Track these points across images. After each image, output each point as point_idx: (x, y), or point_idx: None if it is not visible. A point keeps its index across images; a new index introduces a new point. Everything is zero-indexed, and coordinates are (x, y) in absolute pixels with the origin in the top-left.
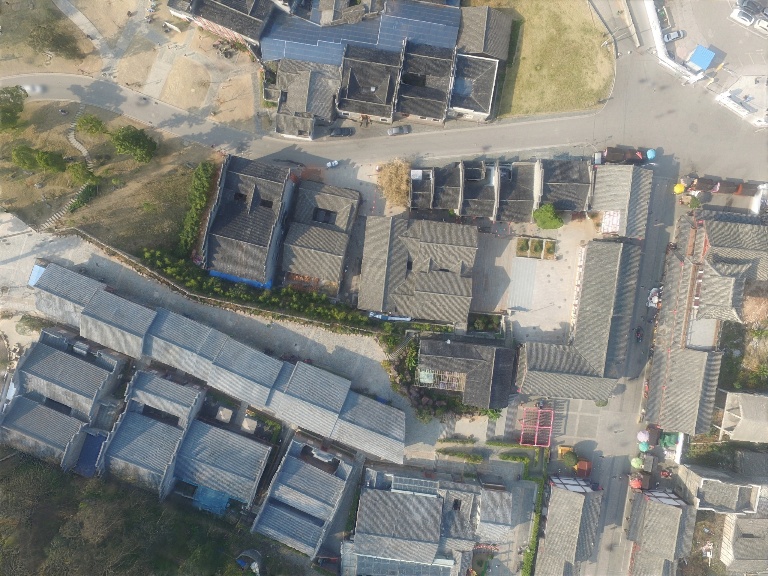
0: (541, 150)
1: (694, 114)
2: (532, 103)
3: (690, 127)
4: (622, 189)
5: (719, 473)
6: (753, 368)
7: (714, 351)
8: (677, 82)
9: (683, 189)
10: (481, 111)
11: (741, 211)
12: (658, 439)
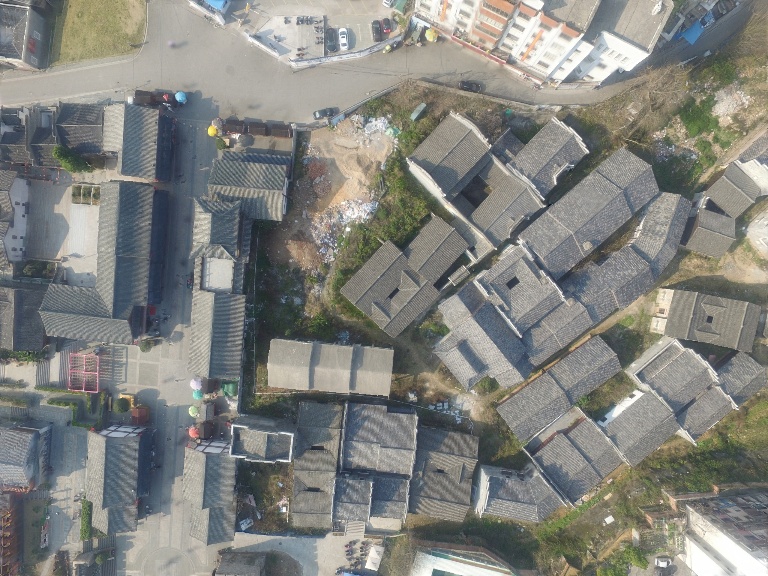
0: (87, 96)
1: (229, 56)
2: (76, 50)
3: (226, 69)
4: (120, 128)
5: (268, 422)
6: None
7: (229, 293)
8: (209, 24)
9: (214, 131)
10: (16, 58)
11: (286, 154)
12: (213, 387)
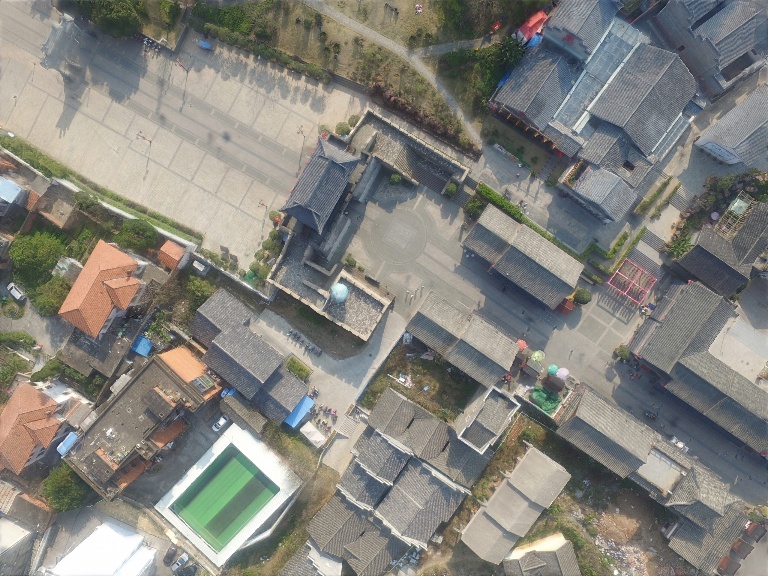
0: None
1: None
2: None
3: None
4: None
5: None
6: (557, 502)
7: None
8: None
9: (765, 514)
10: None
11: None
12: (551, 386)
